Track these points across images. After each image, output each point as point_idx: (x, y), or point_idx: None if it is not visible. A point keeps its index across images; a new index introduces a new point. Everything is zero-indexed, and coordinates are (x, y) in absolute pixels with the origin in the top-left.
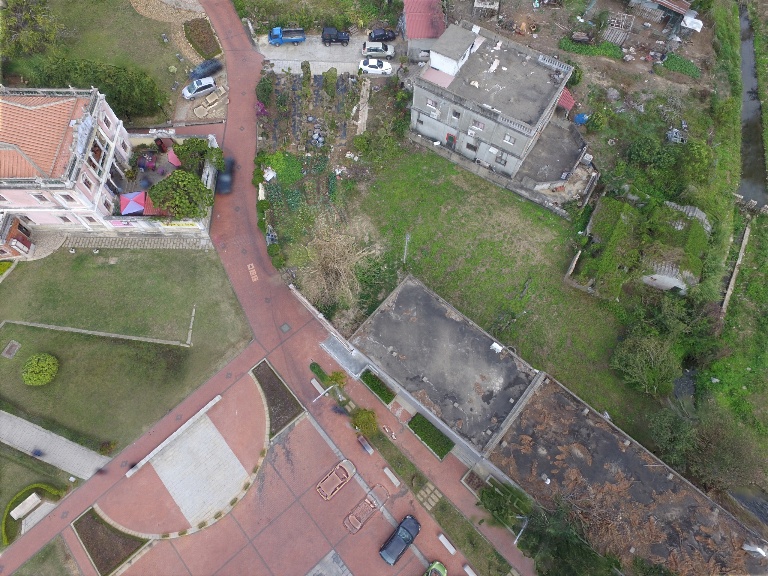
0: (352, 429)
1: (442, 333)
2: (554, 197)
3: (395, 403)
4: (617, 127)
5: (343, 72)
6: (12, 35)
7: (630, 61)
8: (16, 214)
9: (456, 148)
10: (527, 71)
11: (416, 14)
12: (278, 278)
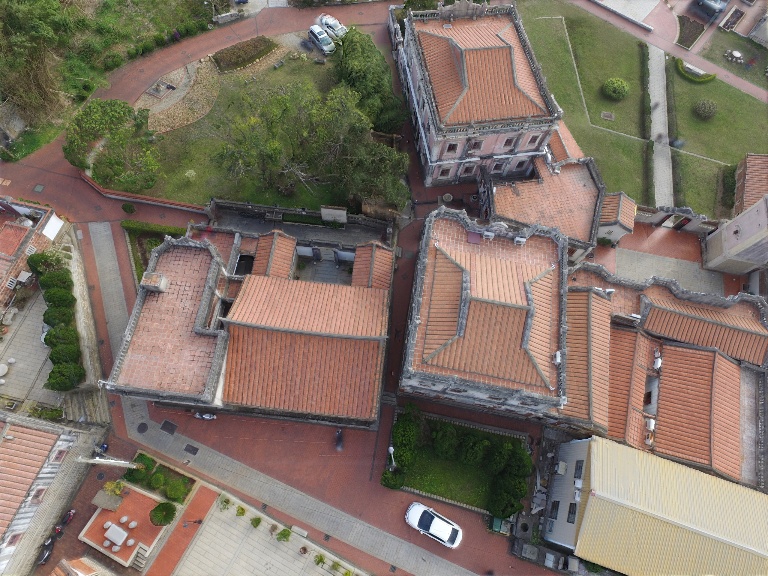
0: None
1: None
2: None
3: None
4: None
5: None
6: None
7: None
8: None
9: None
10: None
11: None
12: None
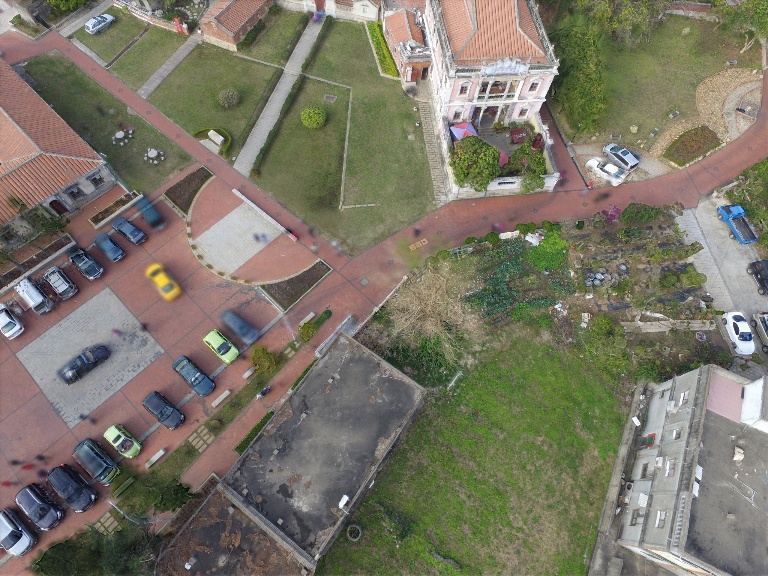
0: None
1: (359, 433)
2: None
3: None
4: None
5: (713, 295)
6: None
7: None
8: None
9: (641, 451)
10: None
11: None
12: None
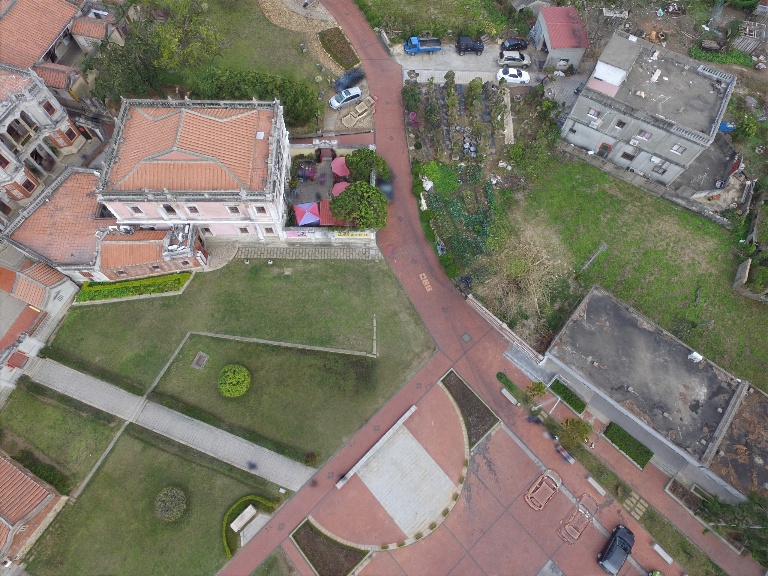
0: (549, 439)
1: (638, 343)
2: (711, 205)
3: (586, 412)
4: (762, 135)
5: None
6: (179, 47)
7: (762, 69)
8: (199, 225)
9: (608, 157)
10: (688, 81)
11: (557, 24)
12: (451, 288)
